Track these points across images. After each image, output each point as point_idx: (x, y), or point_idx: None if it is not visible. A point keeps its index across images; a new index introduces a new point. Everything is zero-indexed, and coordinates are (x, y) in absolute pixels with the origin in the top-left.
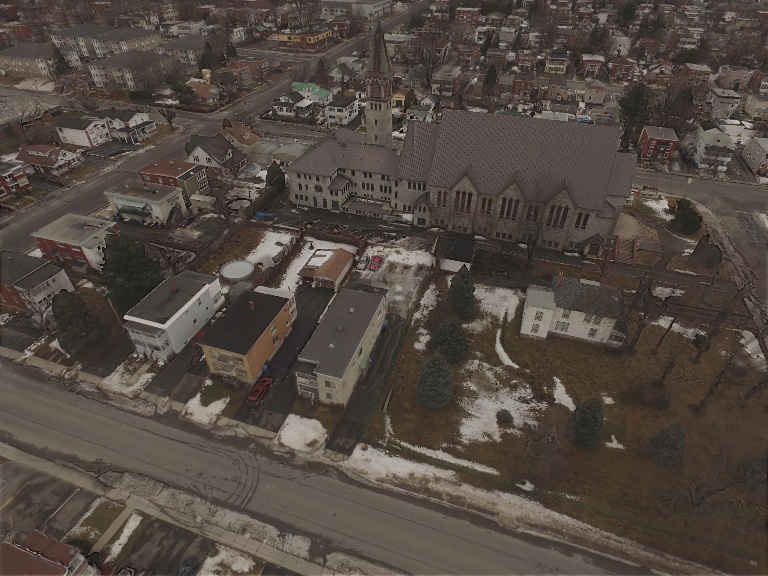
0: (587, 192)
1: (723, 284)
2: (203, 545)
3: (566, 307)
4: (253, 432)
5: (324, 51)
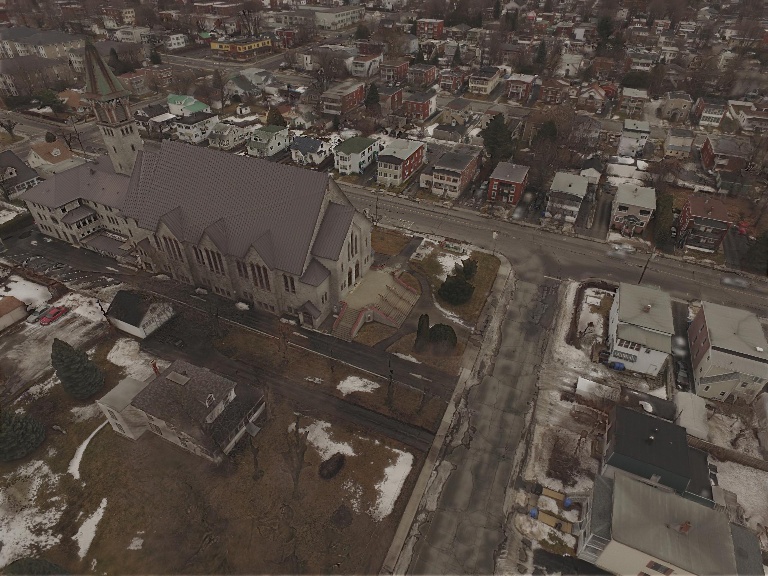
0: (286, 251)
1: (440, 379)
2: None
3: (141, 408)
4: None
5: (255, 61)
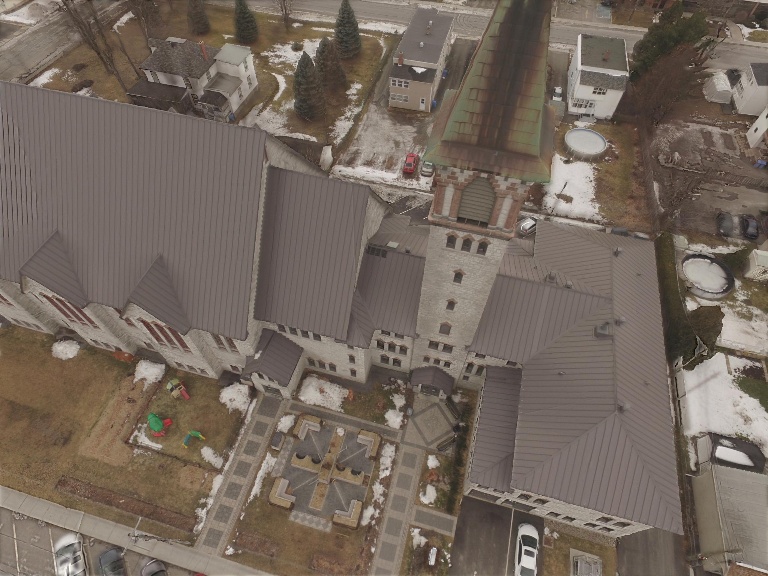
0: None
1: None
2: (471, 5)
3: None
4: (473, 38)
5: None
